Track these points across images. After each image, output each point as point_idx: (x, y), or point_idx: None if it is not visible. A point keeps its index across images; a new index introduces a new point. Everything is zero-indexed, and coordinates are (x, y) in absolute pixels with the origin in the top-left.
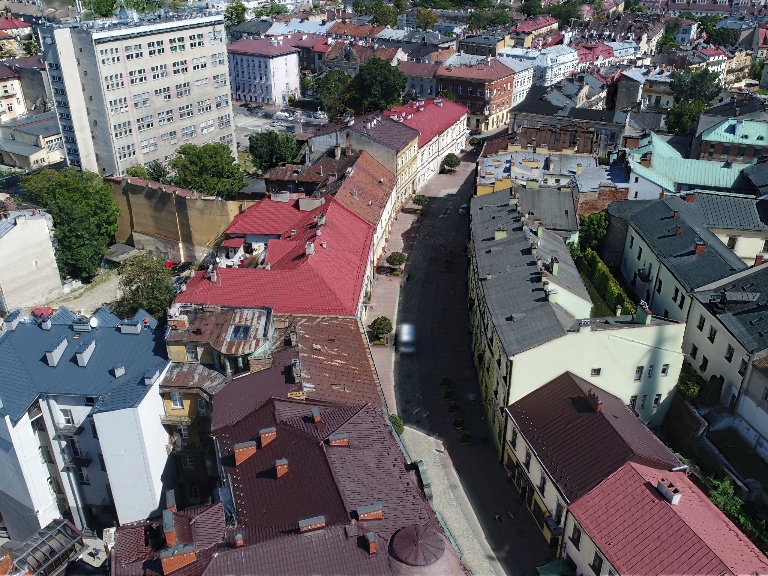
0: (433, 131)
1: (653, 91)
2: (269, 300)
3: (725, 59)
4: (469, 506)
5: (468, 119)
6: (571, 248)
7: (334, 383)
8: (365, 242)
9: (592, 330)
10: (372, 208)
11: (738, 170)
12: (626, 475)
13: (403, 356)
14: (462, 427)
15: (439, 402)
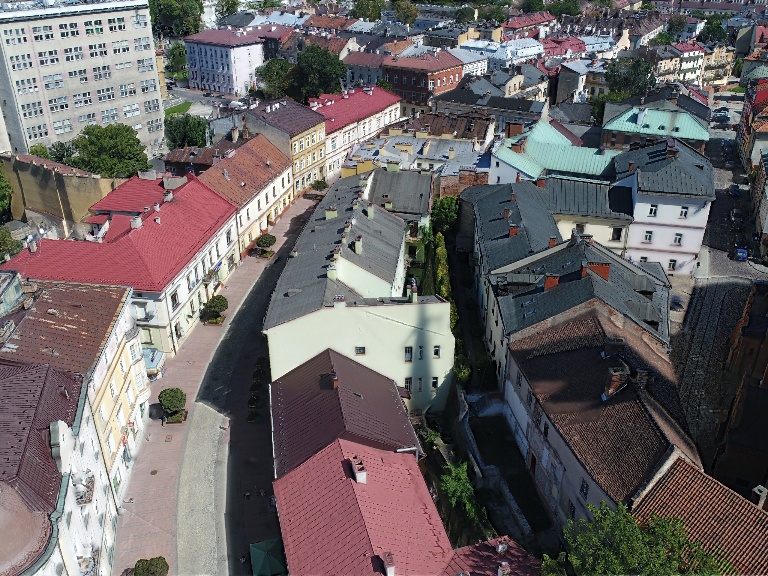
0: (350, 118)
1: (596, 83)
2: (82, 272)
3: (702, 55)
4: (224, 482)
5: (413, 110)
6: (423, 232)
7: (46, 346)
8: (217, 221)
9: (347, 306)
10: (245, 189)
11: (610, 157)
12: (331, 452)
13: (233, 335)
14: (255, 405)
15: (246, 380)
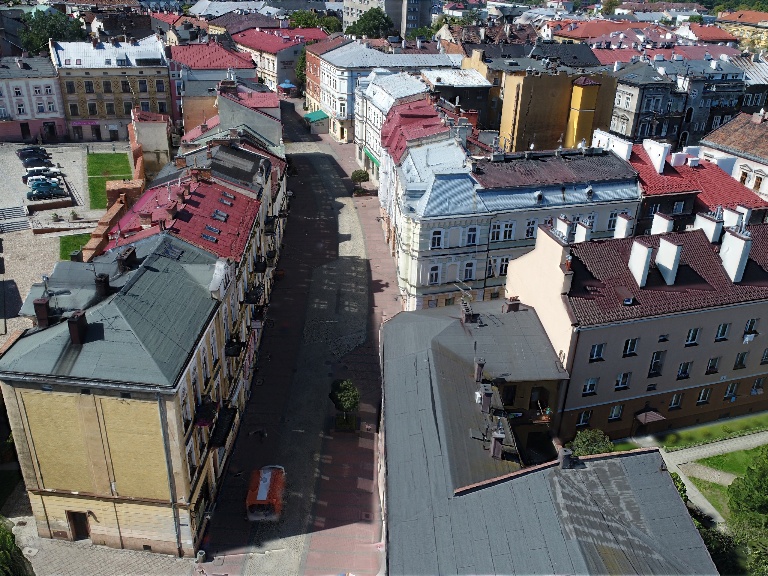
0: None
1: None
2: None
3: None
4: None
5: None
6: None
7: None
8: None
9: (26, 3)
10: None
11: None
12: None
13: None
14: None
15: None
